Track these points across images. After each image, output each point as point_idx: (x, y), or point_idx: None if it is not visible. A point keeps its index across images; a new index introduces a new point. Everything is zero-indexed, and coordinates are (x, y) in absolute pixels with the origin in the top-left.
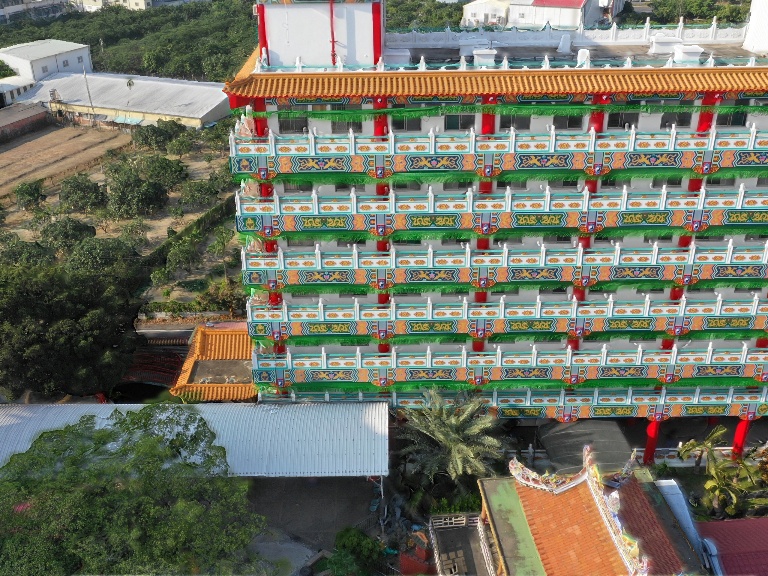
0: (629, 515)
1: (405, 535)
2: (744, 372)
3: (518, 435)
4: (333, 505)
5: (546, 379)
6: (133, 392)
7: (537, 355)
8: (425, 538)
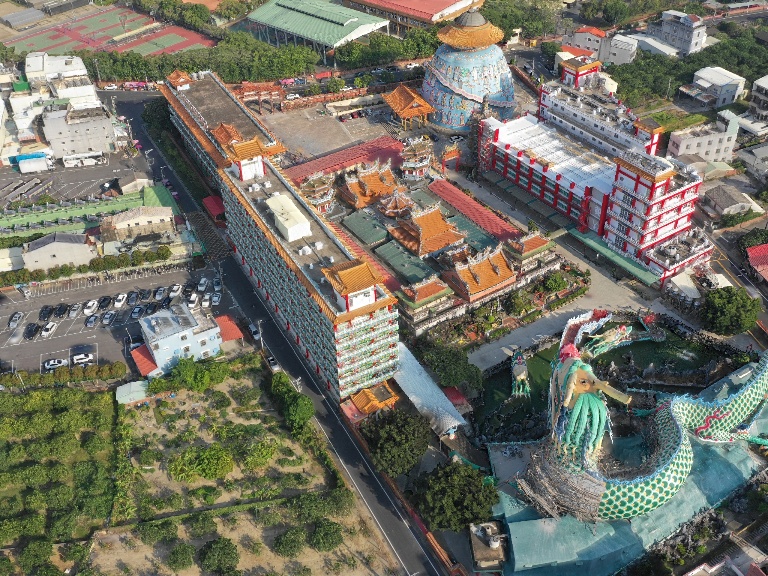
0: None
1: None
2: None
3: None
4: None
5: None
6: None
7: None
8: None
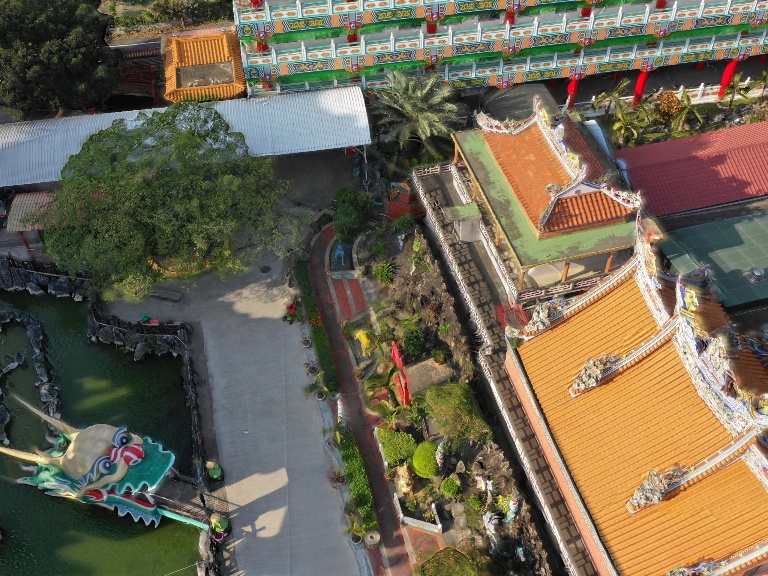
0: (568, 143)
1: (386, 191)
2: (646, 31)
3: None
4: (322, 176)
5: (489, 52)
6: (119, 104)
7: (482, 32)
8: (408, 187)
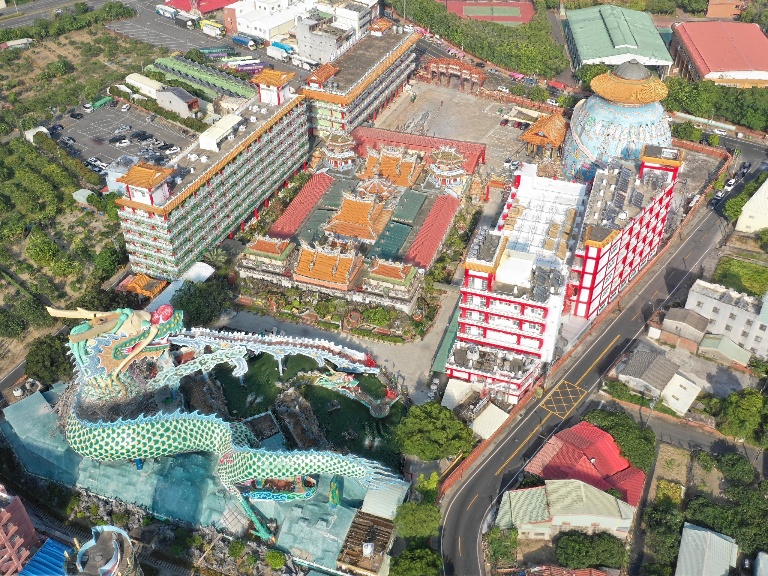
0: None
1: None
2: None
3: None
4: None
5: None
6: None
7: None
8: (233, 273)
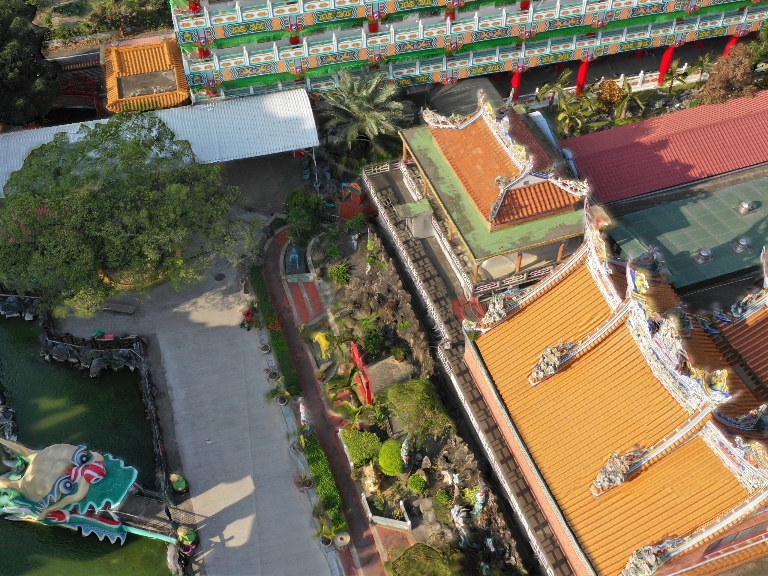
0: (514, 135)
1: (337, 192)
2: (584, 21)
3: (411, 101)
4: (272, 180)
5: (432, 49)
6: (60, 117)
7: (423, 29)
8: (359, 187)
